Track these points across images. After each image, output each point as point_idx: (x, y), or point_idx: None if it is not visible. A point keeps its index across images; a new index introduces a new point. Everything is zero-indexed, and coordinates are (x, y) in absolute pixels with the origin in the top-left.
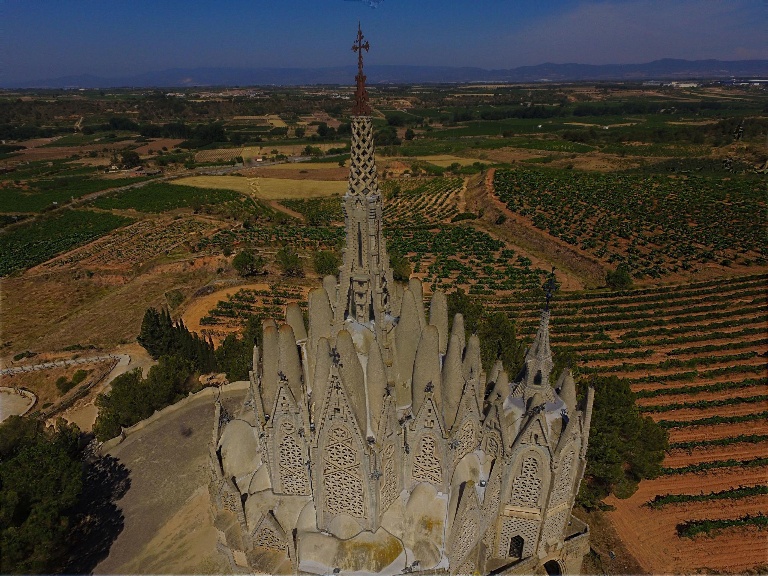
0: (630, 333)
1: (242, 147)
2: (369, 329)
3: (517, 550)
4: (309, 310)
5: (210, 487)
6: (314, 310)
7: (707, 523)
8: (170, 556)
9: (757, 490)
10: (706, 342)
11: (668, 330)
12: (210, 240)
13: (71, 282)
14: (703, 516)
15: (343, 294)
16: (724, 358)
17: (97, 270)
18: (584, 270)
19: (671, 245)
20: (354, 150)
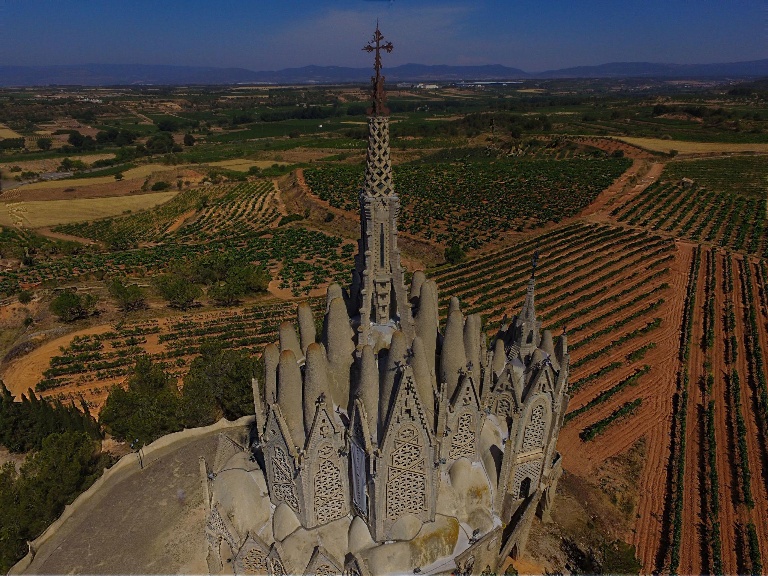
0: (483, 297)
1: None
2: (393, 328)
3: (523, 491)
4: (302, 326)
5: (209, 558)
6: (334, 322)
7: (600, 425)
8: None
9: (614, 391)
10: (534, 292)
11: (507, 289)
12: None
13: None
14: (591, 421)
15: (369, 298)
16: (552, 302)
17: None
18: (420, 252)
19: (477, 221)
20: (374, 151)
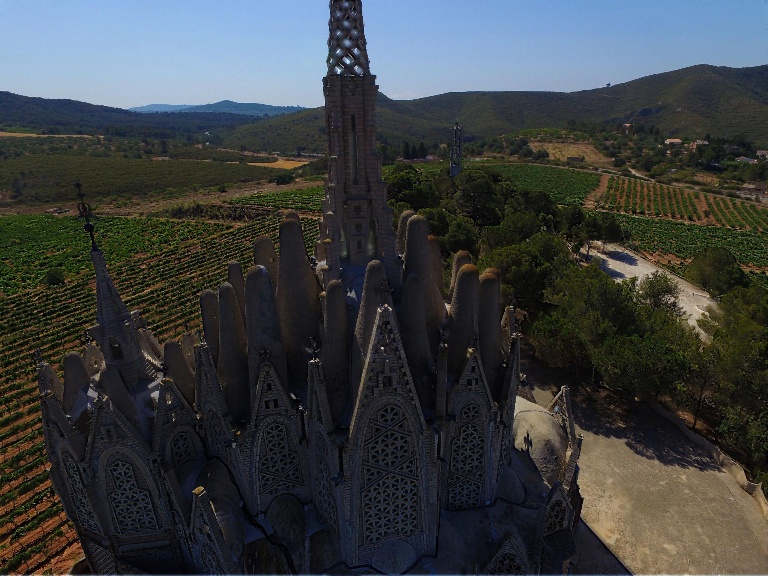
0: None
1: None
2: None
3: None
4: None
5: None
6: None
7: None
8: None
9: None
10: None
11: None
12: None
13: None
14: None
15: None
16: None
17: None
18: None
19: None
20: None
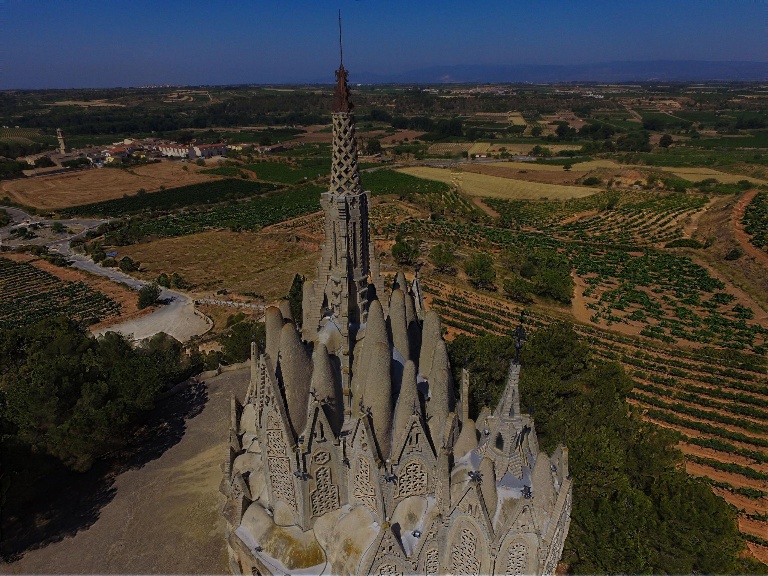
0: None
1: (453, 142)
2: (340, 331)
3: None
4: None
5: None
6: None
7: None
8: (193, 477)
9: None
10: None
11: None
12: (396, 226)
13: (284, 243)
14: None
15: (319, 290)
16: None
17: (303, 237)
18: None
19: None
20: None
